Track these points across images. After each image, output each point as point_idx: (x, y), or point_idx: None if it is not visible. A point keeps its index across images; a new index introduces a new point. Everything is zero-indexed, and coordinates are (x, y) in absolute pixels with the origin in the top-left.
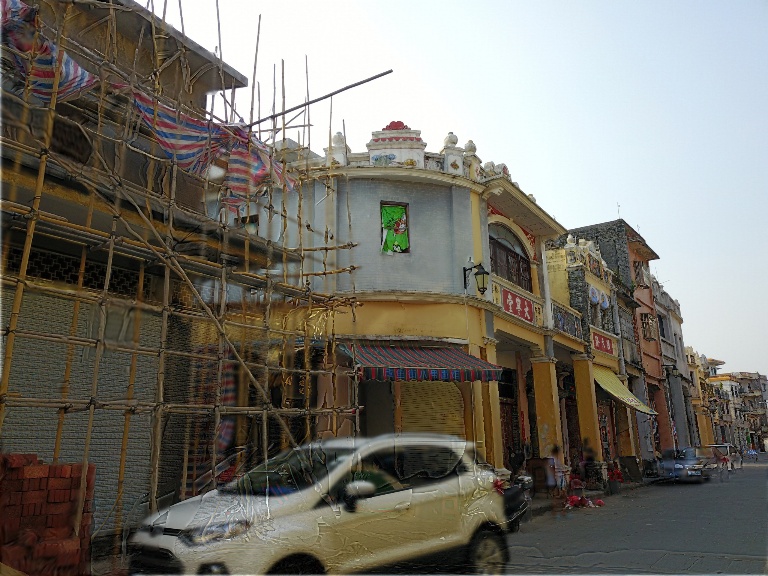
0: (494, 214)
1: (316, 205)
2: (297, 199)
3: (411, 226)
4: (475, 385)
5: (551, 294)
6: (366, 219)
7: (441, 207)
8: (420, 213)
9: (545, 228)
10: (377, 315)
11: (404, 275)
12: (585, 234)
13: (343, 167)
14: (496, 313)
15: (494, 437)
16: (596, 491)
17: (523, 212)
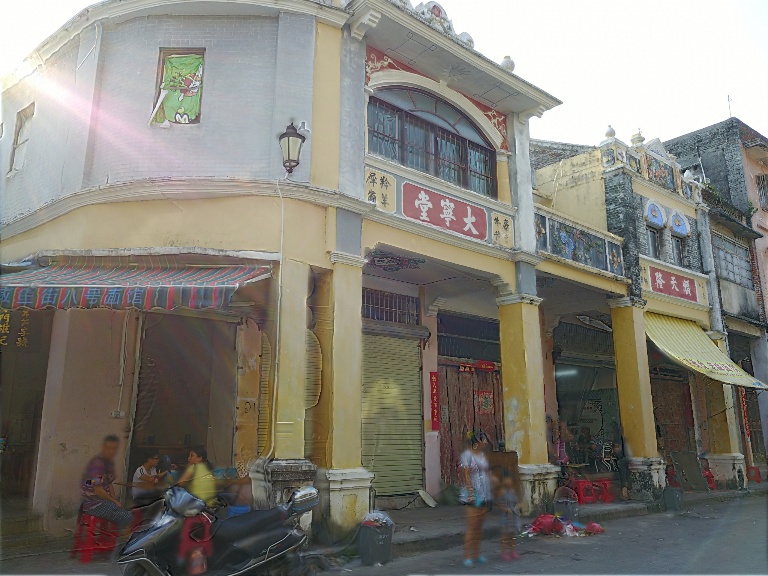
0: (395, 69)
1: (77, 69)
2: (66, 68)
3: (206, 82)
4: (285, 327)
5: (582, 215)
6: (134, 77)
7: (260, 49)
8: (223, 61)
9: (512, 96)
10: (140, 222)
11: (186, 157)
12: (681, 146)
13: (102, 3)
14: (375, 217)
15: (336, 416)
16: (633, 504)
17: (452, 64)
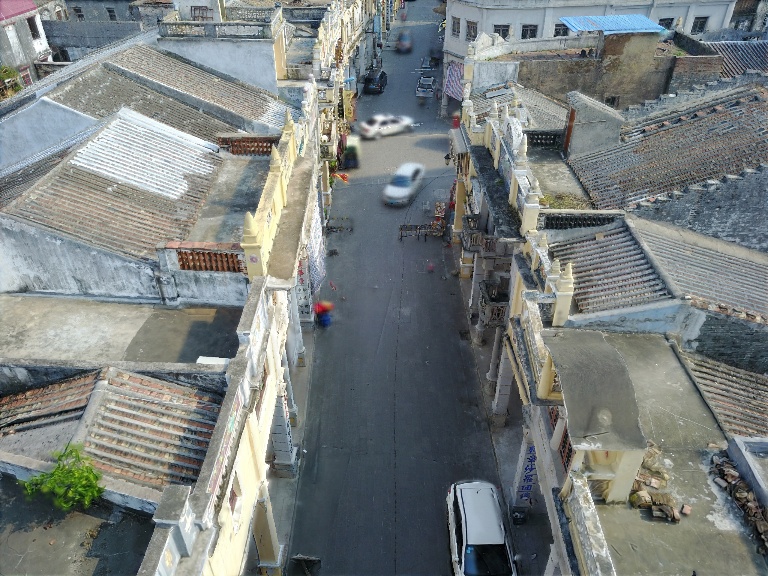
0: None
1: None
2: None
3: None
4: None
5: None
6: None
7: None
8: None
9: None
10: None
11: None
12: None
13: None
14: None
15: None
16: None
17: None
